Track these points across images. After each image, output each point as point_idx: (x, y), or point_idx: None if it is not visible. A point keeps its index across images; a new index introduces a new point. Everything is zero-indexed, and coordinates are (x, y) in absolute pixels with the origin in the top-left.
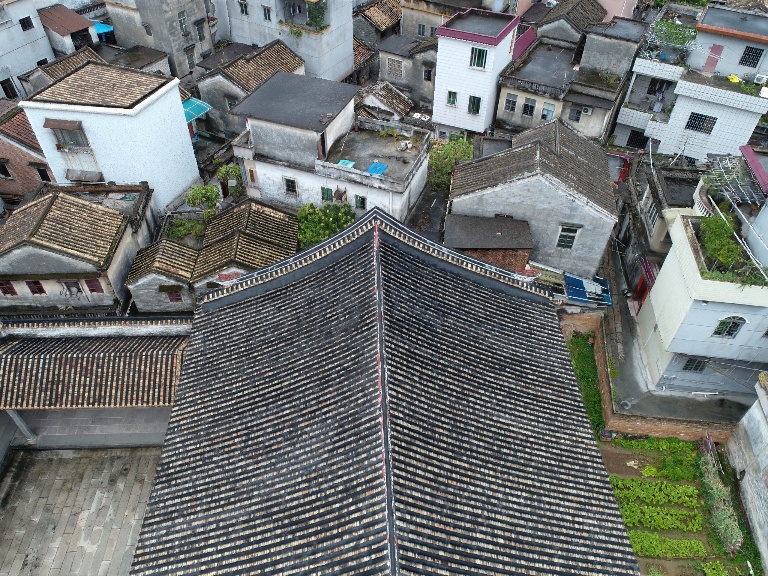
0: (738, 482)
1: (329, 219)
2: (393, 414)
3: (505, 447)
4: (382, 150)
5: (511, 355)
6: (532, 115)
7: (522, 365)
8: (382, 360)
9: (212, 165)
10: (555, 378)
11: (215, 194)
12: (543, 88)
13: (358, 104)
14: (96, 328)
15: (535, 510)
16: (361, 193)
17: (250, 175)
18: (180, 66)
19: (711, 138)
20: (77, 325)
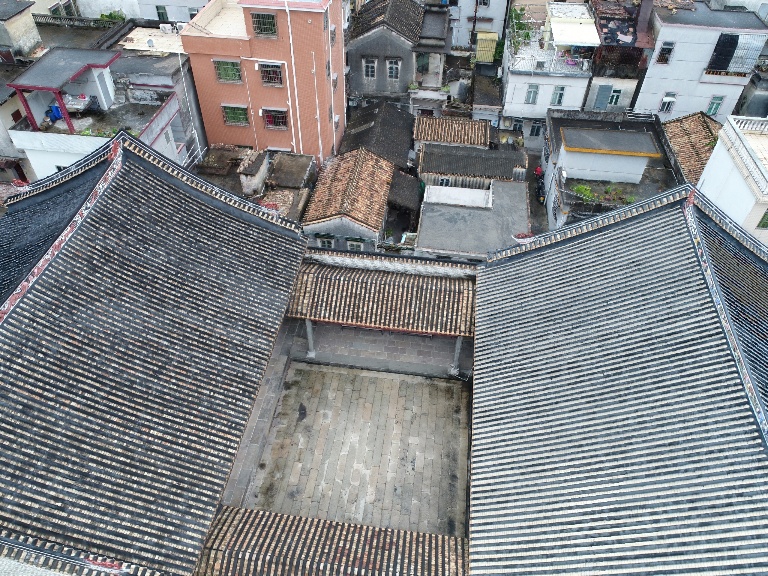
0: None
1: None
2: None
3: None
4: None
5: None
6: None
7: None
8: None
9: None
10: None
11: None
12: None
13: None
14: None
15: None
16: None
17: None
18: None
19: None
20: None
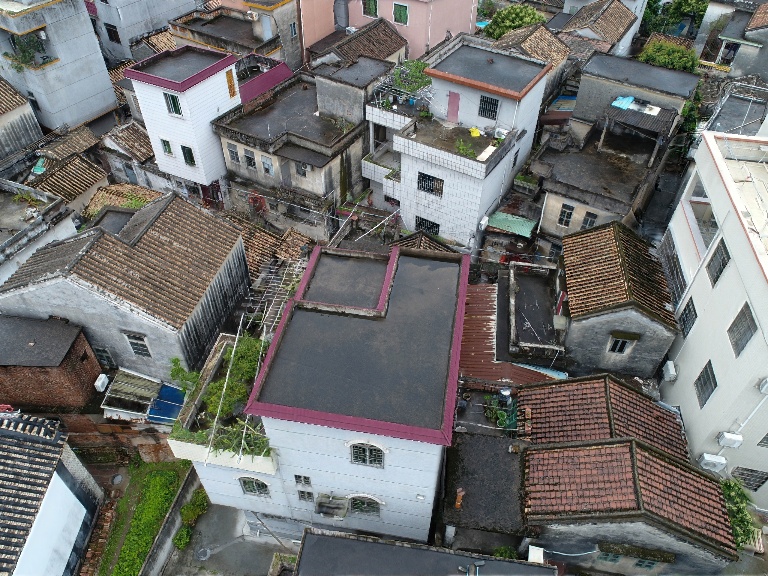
0: None
1: None
2: None
3: None
4: (2, 219)
5: None
6: (257, 168)
7: None
8: None
9: None
10: None
11: None
12: (252, 140)
13: (98, 146)
14: None
15: None
16: None
17: None
18: None
19: (444, 202)
20: None
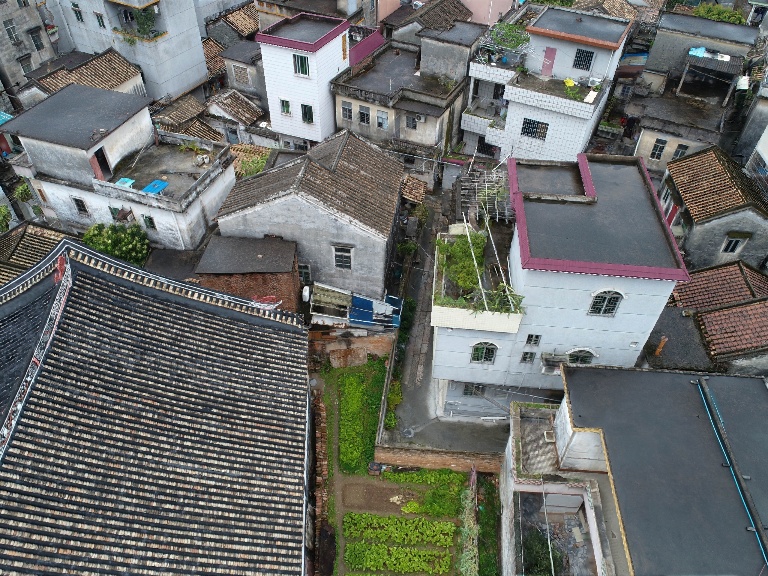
0: (500, 517)
1: (109, 241)
2: (2, 477)
3: (168, 502)
4: (177, 166)
5: (226, 393)
6: (369, 123)
7: (237, 403)
8: (3, 414)
9: (20, 183)
10: (277, 416)
11: (3, 215)
12: (372, 95)
13: (203, 114)
14: None
15: (180, 575)
16: (146, 212)
17: (40, 194)
18: (14, 77)
19: (546, 144)
20: None
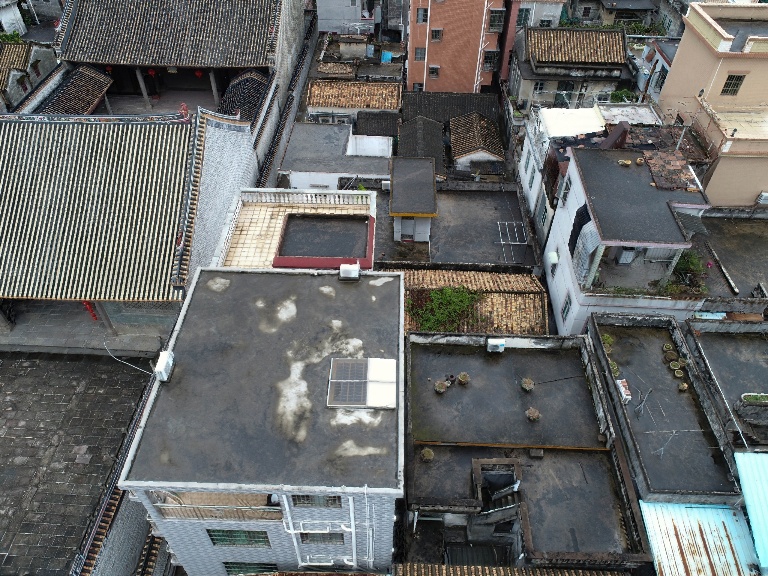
0: None
1: None
2: None
3: None
4: None
5: None
6: None
7: None
8: None
9: None
10: None
11: None
12: None
13: None
14: (35, 98)
15: None
16: None
17: None
18: None
19: None
20: (30, 99)
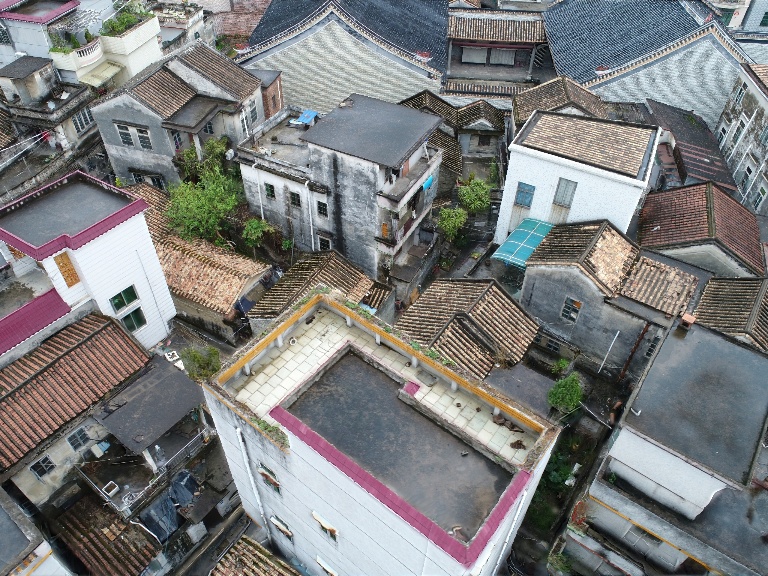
0: None
1: None
2: None
3: None
4: (292, 152)
5: None
6: None
7: None
8: None
9: None
10: None
11: None
12: None
13: None
14: None
15: None
16: None
17: None
18: None
19: None
20: None
